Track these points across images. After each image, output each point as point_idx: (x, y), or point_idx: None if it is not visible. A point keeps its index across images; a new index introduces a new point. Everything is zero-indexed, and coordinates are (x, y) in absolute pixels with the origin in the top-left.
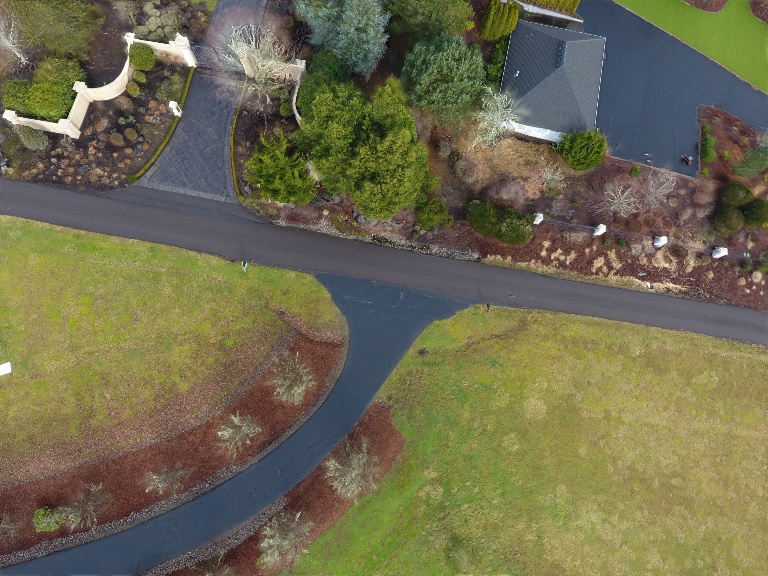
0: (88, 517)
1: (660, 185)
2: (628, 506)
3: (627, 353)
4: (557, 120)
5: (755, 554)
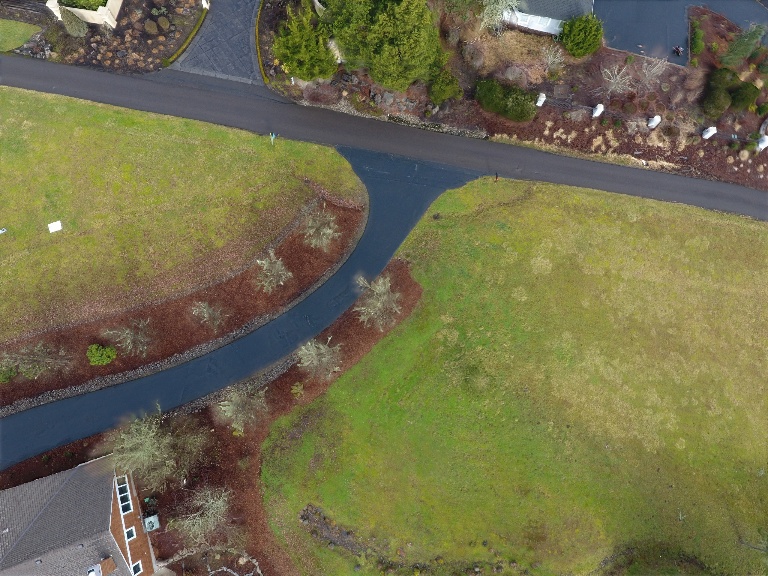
0: (139, 344)
1: (653, 67)
2: (628, 351)
3: (625, 219)
4: (557, 8)
5: (745, 395)
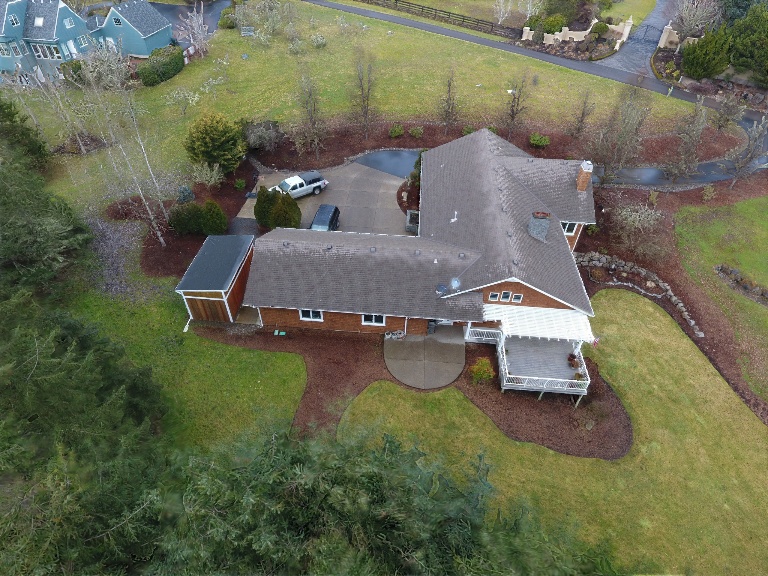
0: None
1: None
2: None
3: None
4: None
5: None
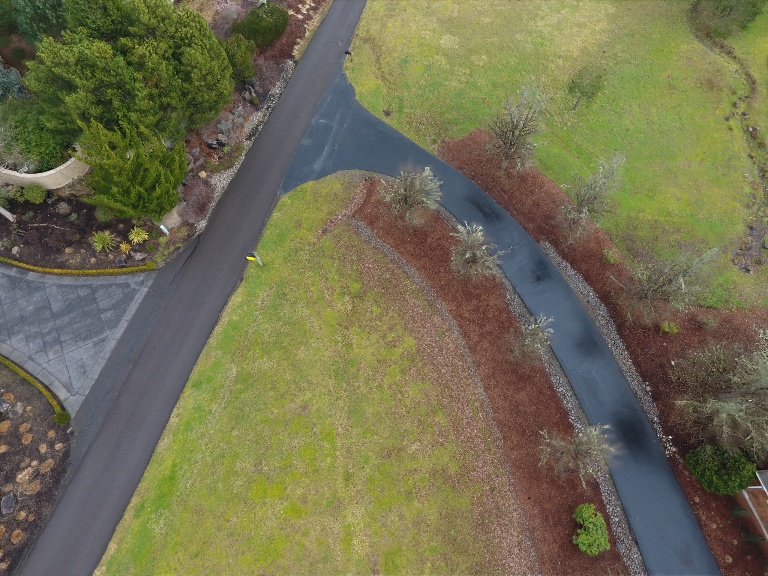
0: None
1: None
2: (530, 4)
3: None
4: None
5: None
